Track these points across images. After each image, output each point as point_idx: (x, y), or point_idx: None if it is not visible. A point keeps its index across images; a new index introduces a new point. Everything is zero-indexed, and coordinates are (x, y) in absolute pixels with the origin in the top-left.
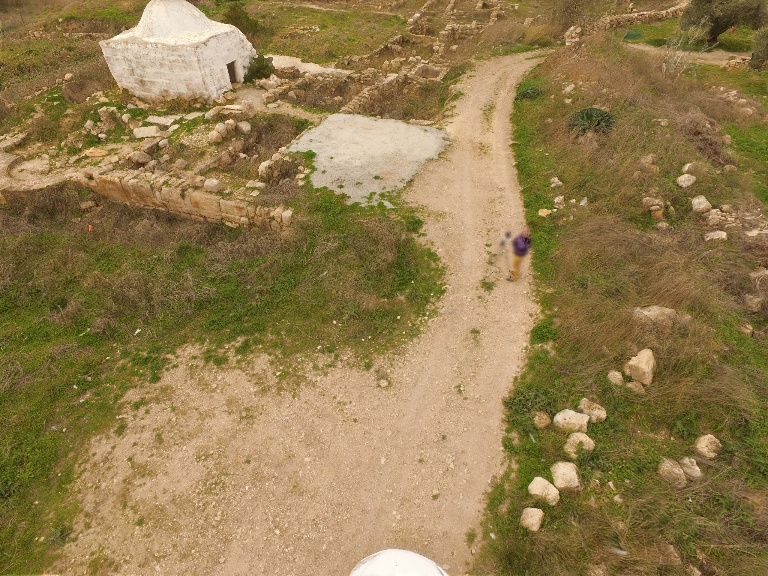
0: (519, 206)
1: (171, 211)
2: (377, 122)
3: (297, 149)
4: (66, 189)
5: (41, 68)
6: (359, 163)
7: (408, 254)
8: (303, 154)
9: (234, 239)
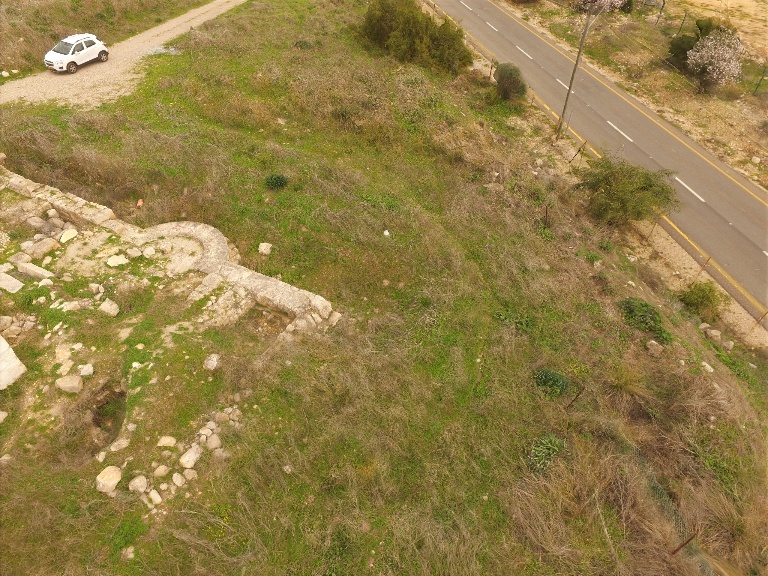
0: None
1: None
2: None
3: None
4: None
5: None
6: None
7: None
8: None
9: None
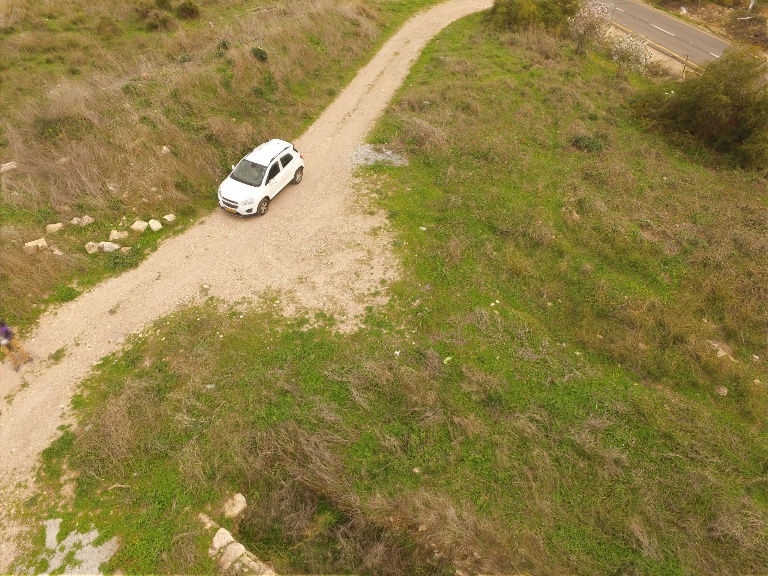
0: None
1: None
2: None
3: None
4: None
5: None
6: None
7: None
8: None
9: (322, 546)
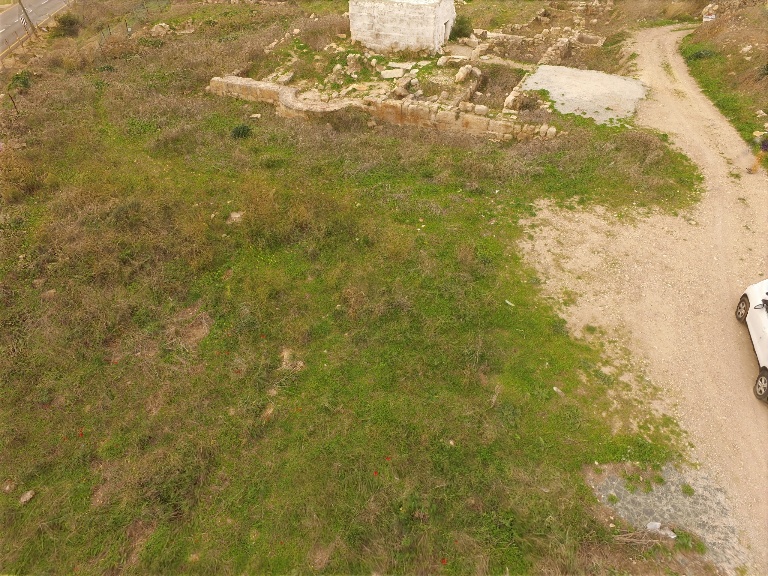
0: (732, 130)
1: (439, 130)
2: (582, 72)
3: (529, 88)
4: (357, 111)
5: (249, 26)
6: (587, 99)
7: (664, 156)
8: (538, 92)
9: None
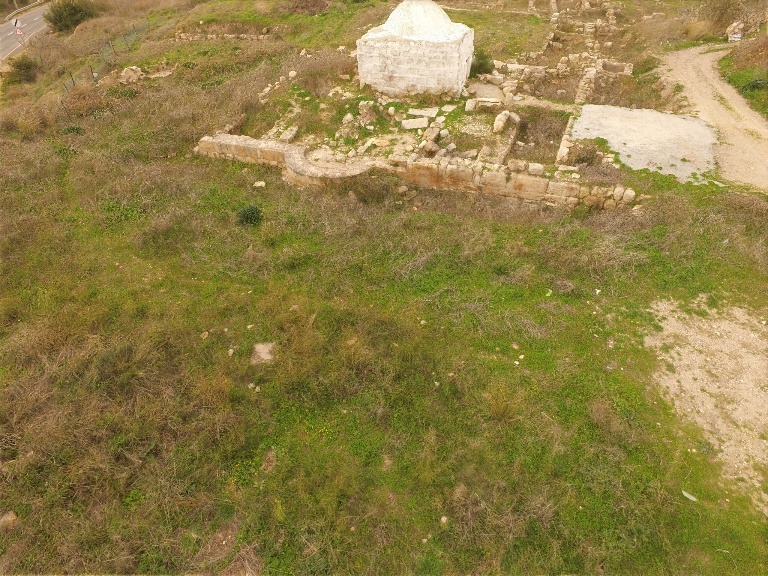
0: None
1: (485, 194)
2: (634, 112)
3: (582, 136)
4: (384, 175)
5: (233, 67)
6: (655, 148)
7: None
8: (594, 141)
9: (575, 216)
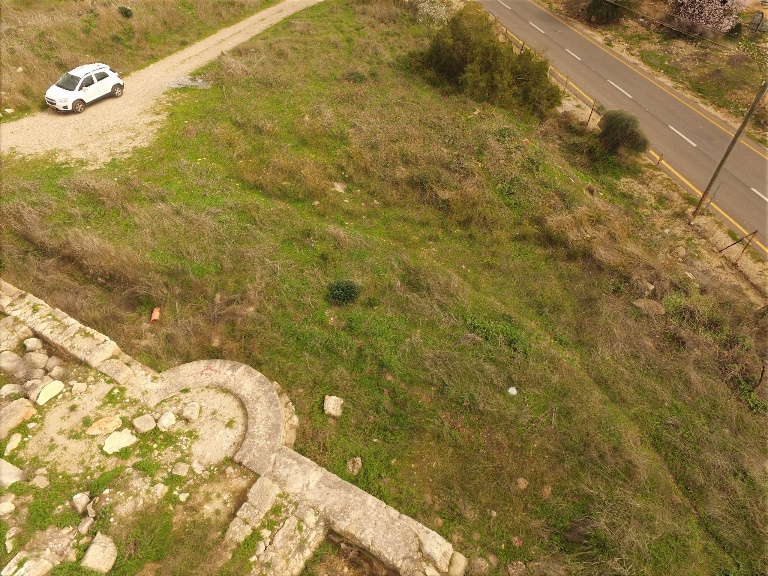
0: None
1: None
2: None
3: None
4: None
5: None
6: None
7: None
8: None
9: None
